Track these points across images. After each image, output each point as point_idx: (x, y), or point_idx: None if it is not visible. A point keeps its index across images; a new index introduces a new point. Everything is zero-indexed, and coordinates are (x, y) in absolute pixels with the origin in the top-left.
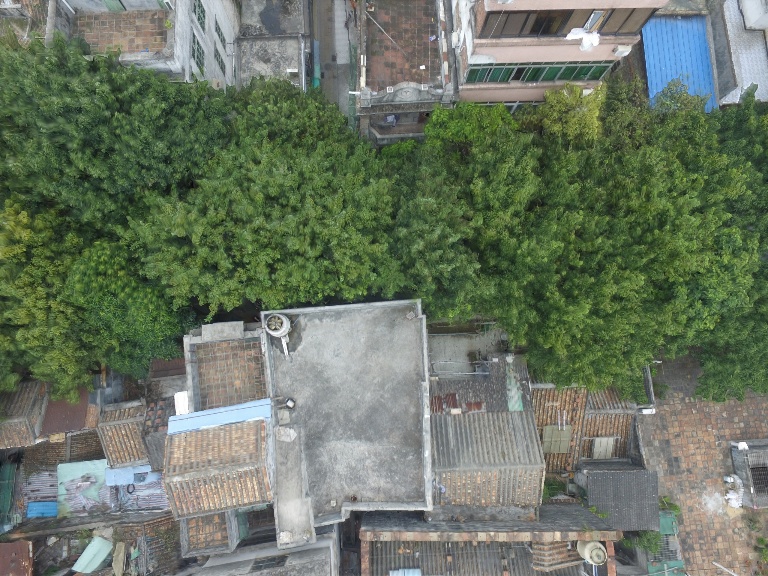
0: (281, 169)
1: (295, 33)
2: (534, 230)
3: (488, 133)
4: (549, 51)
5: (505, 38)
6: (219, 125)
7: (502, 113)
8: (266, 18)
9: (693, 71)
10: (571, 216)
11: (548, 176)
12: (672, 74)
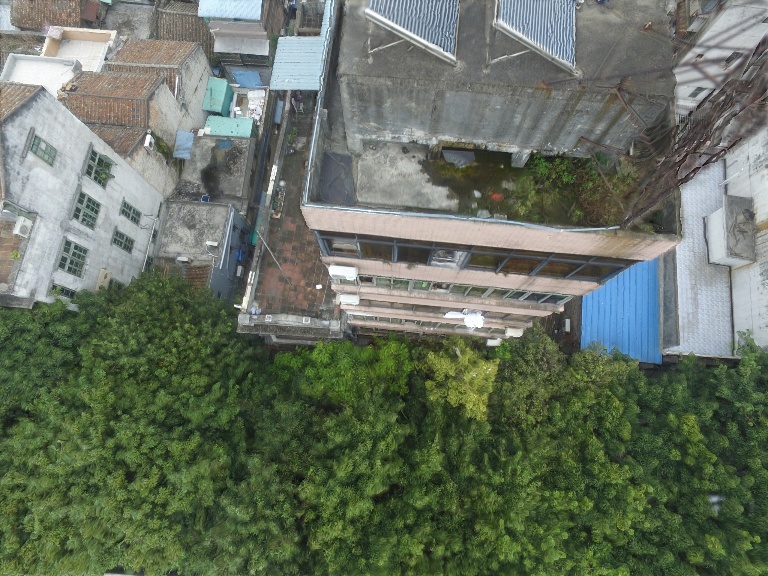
0: (82, 446)
1: (232, 195)
2: (374, 540)
3: (364, 386)
4: (432, 319)
5: (376, 307)
6: (61, 354)
7: (394, 352)
8: (207, 176)
9: (636, 310)
10: (410, 542)
11: (413, 460)
12: (611, 311)
